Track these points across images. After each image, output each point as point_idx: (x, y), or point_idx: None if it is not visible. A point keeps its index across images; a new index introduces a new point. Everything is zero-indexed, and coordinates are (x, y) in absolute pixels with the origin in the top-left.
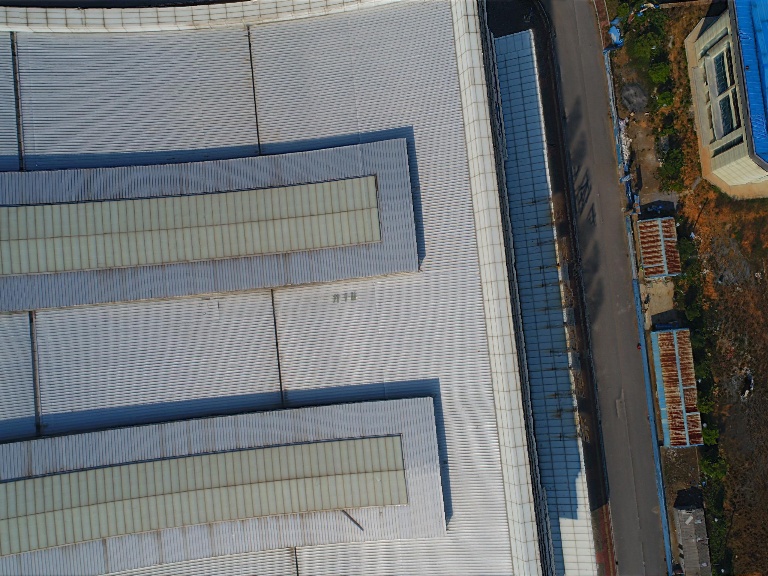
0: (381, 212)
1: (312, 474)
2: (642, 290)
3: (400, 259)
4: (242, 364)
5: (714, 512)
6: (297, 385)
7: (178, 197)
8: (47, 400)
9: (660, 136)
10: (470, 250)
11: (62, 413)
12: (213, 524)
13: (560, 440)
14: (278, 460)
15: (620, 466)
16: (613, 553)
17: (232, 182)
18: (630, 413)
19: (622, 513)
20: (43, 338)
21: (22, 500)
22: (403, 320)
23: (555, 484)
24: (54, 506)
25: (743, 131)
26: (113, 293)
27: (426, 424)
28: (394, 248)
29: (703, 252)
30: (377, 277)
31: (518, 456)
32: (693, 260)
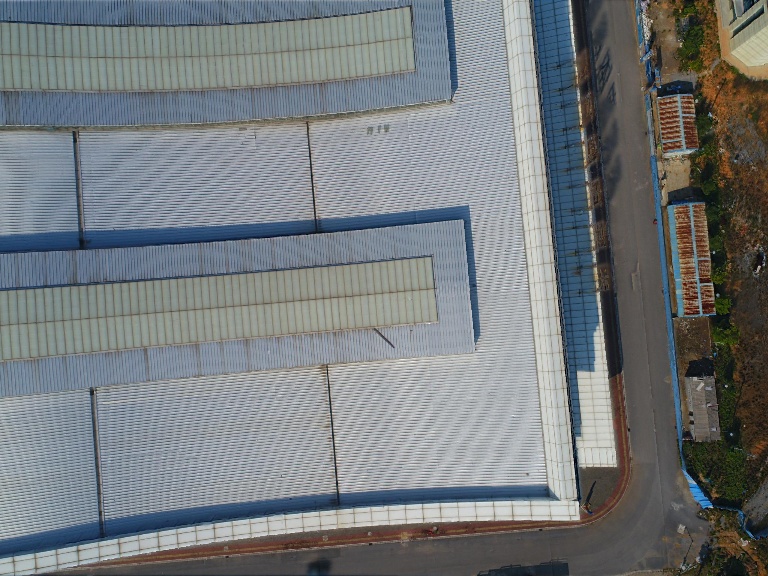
0: (416, 42)
1: (345, 294)
2: (659, 167)
3: (434, 87)
4: (278, 193)
5: (724, 382)
6: (331, 214)
7: (218, 26)
8: (90, 217)
9: (681, 17)
10: (502, 80)
11: (104, 231)
12: (249, 340)
13: (579, 296)
14: (313, 280)
15: (634, 337)
16: (625, 420)
17: (270, 13)
18: (645, 286)
19: (635, 382)
20: (86, 158)
21: (68, 305)
22: (435, 150)
23: (573, 339)
24: (98, 313)
25: (764, 1)
26: (154, 115)
27: (457, 245)
28: (428, 77)
29: (720, 132)
30: (410, 109)
31: (546, 272)
32: (710, 138)
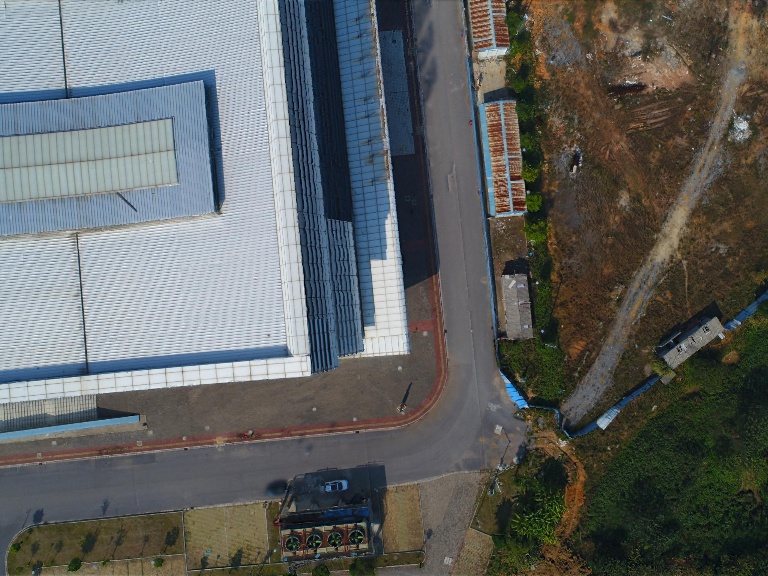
0: None
1: (88, 158)
2: (475, 69)
3: None
4: (28, 62)
5: (540, 282)
6: (81, 83)
7: None
8: None
9: None
10: None
11: None
12: None
13: (372, 185)
14: (55, 145)
15: (450, 238)
16: (442, 321)
17: None
18: (461, 187)
19: (451, 283)
20: None
21: None
22: (183, 16)
23: (367, 228)
24: None
25: None
26: None
27: (196, 106)
28: None
29: (536, 33)
30: None
31: (279, 129)
32: (525, 39)
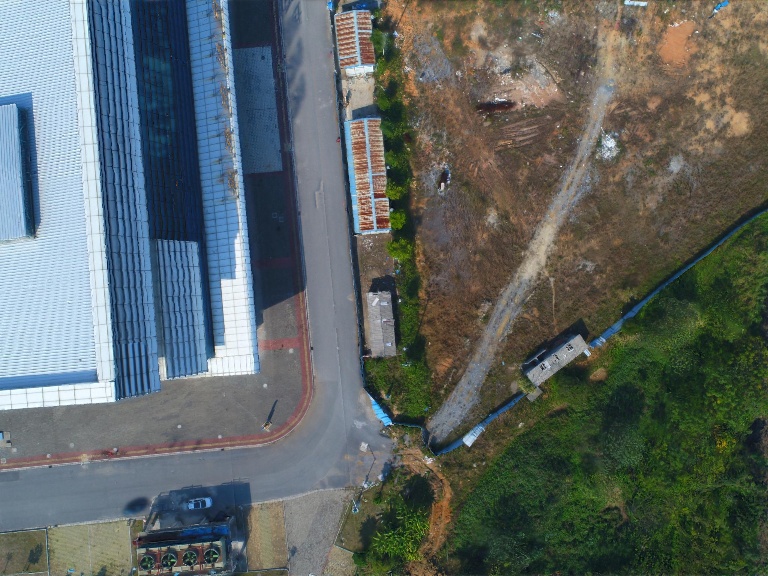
0: None
1: None
2: (344, 86)
3: None
4: None
5: (407, 299)
6: None
7: None
8: None
9: None
10: None
11: None
12: None
13: (222, 204)
14: None
15: (317, 255)
16: (308, 338)
17: None
18: (328, 204)
19: (318, 300)
20: None
21: None
22: (1, 38)
23: (218, 247)
24: None
25: None
26: None
27: (9, 129)
28: None
29: (405, 50)
30: None
31: (87, 153)
32: (393, 56)
